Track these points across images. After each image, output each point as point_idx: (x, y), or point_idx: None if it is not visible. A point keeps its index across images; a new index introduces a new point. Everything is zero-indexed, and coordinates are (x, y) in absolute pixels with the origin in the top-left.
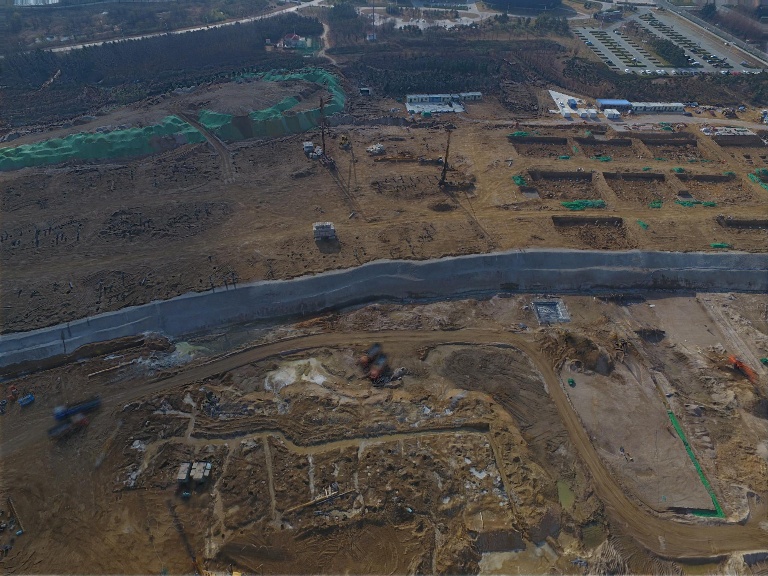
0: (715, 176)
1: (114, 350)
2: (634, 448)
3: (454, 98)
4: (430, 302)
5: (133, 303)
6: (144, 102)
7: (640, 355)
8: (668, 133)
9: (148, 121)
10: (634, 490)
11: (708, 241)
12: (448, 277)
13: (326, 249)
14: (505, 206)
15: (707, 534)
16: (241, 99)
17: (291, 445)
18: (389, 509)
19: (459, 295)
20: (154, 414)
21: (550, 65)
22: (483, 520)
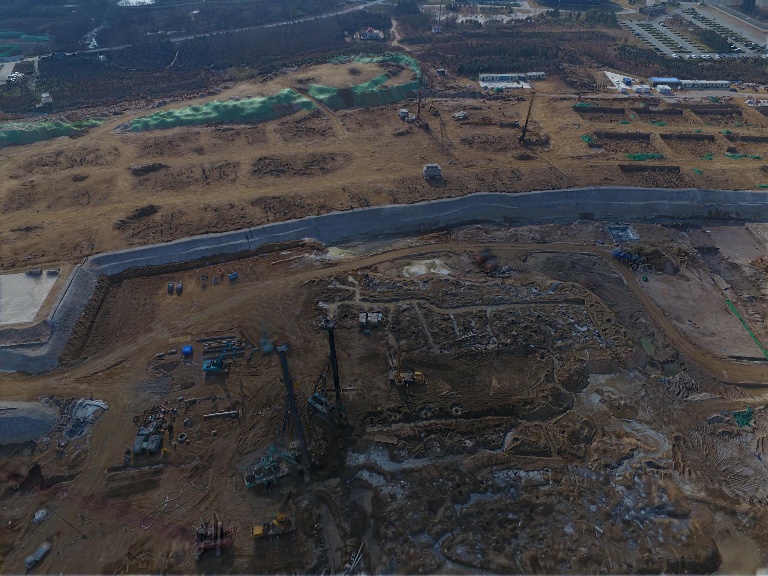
0: (759, 137)
1: (284, 249)
2: (699, 320)
3: (521, 77)
4: (523, 225)
5: (294, 217)
6: (259, 79)
7: (700, 263)
8: (715, 104)
9: (268, 92)
10: (701, 345)
11: (755, 183)
12: (537, 206)
13: (435, 185)
14: (578, 157)
15: (760, 371)
16: (340, 76)
17: (435, 308)
18: (517, 345)
19: (545, 221)
20: (328, 287)
21: (603, 51)
22: (589, 354)
